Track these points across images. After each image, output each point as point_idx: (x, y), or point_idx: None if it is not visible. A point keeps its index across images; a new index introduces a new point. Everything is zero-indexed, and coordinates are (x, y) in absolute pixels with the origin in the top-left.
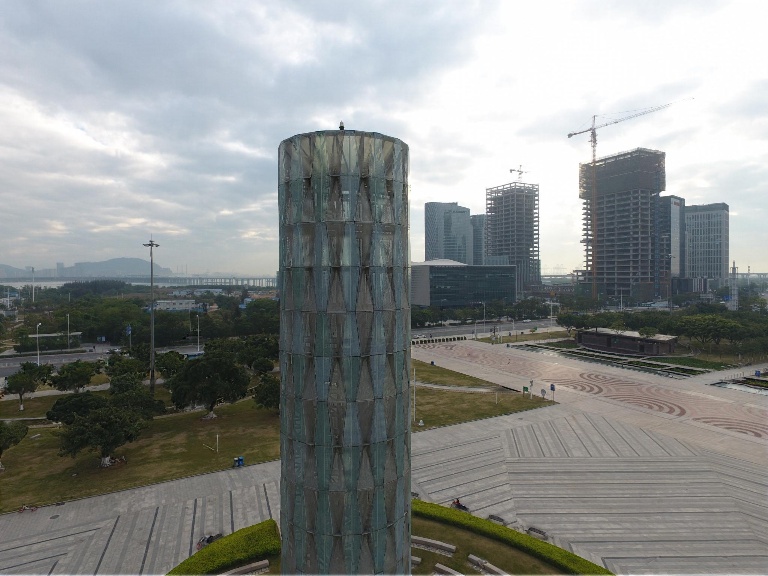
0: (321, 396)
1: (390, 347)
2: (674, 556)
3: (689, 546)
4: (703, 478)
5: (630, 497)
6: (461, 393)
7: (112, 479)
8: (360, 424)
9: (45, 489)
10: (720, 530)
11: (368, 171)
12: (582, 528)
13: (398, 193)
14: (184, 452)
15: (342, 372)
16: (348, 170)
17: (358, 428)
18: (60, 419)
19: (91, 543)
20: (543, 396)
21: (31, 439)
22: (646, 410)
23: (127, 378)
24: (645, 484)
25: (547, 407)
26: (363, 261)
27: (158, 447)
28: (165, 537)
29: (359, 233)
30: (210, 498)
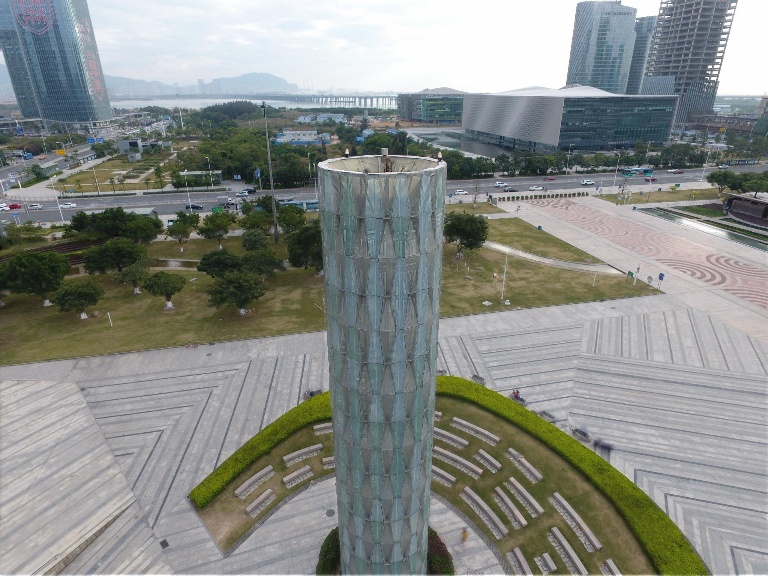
0: (354, 385)
1: (412, 355)
2: (709, 482)
3: (731, 475)
4: None
5: (694, 414)
6: (559, 269)
7: (246, 327)
8: (384, 408)
9: (202, 330)
10: None
11: (392, 213)
12: (628, 437)
13: (426, 223)
14: (299, 309)
15: (368, 374)
16: (373, 211)
17: (381, 412)
18: (207, 272)
19: (233, 381)
20: (649, 283)
21: (190, 282)
22: (767, 313)
23: (254, 234)
24: (718, 403)
25: (648, 297)
26: (387, 290)
27: (279, 301)
28: (282, 385)
29: (383, 267)
30: (315, 355)
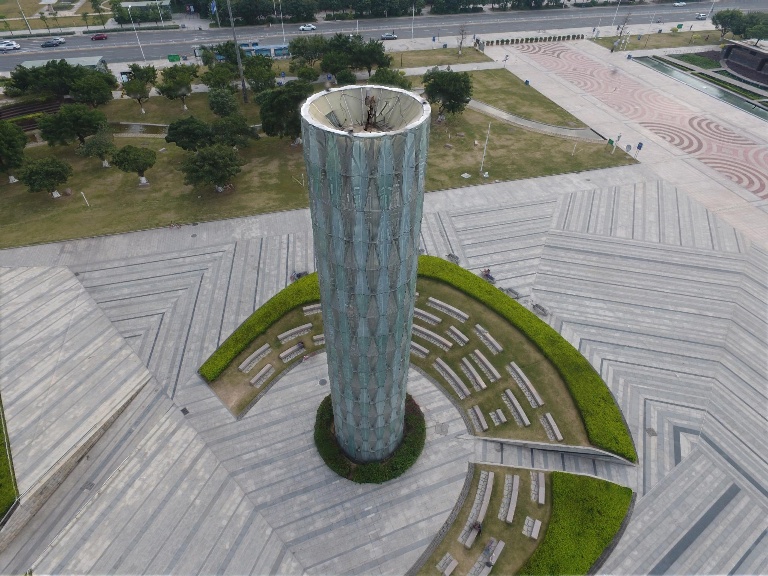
0: (343, 309)
1: (394, 286)
2: (640, 348)
3: (659, 342)
4: (725, 280)
5: (640, 288)
6: (541, 135)
7: (227, 205)
8: (370, 327)
9: (182, 209)
10: (697, 333)
11: (377, 172)
12: (580, 311)
13: (409, 176)
14: (278, 184)
15: (356, 302)
16: (359, 169)
17: (368, 330)
18: (177, 144)
19: (221, 263)
20: (627, 152)
21: (160, 152)
22: (731, 185)
23: (221, 95)
24: (664, 277)
25: (624, 167)
26: (373, 236)
27: (257, 175)
28: (269, 266)
29: (369, 218)
30: (299, 235)
